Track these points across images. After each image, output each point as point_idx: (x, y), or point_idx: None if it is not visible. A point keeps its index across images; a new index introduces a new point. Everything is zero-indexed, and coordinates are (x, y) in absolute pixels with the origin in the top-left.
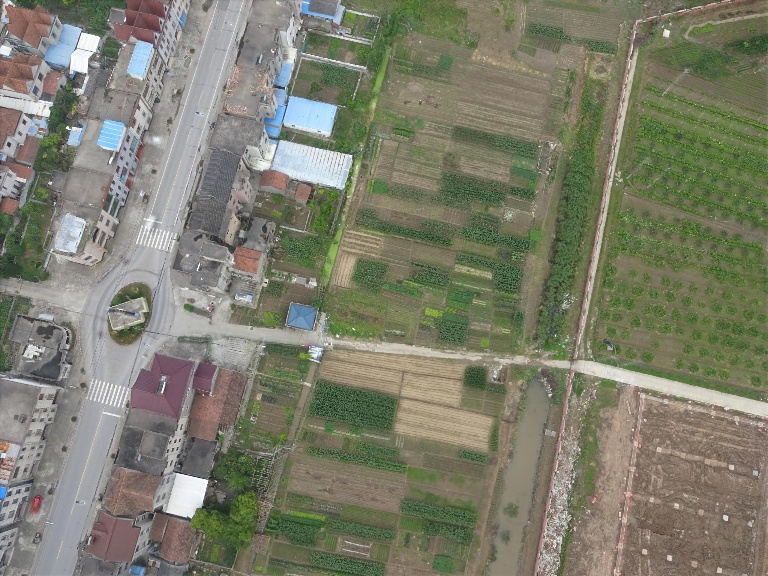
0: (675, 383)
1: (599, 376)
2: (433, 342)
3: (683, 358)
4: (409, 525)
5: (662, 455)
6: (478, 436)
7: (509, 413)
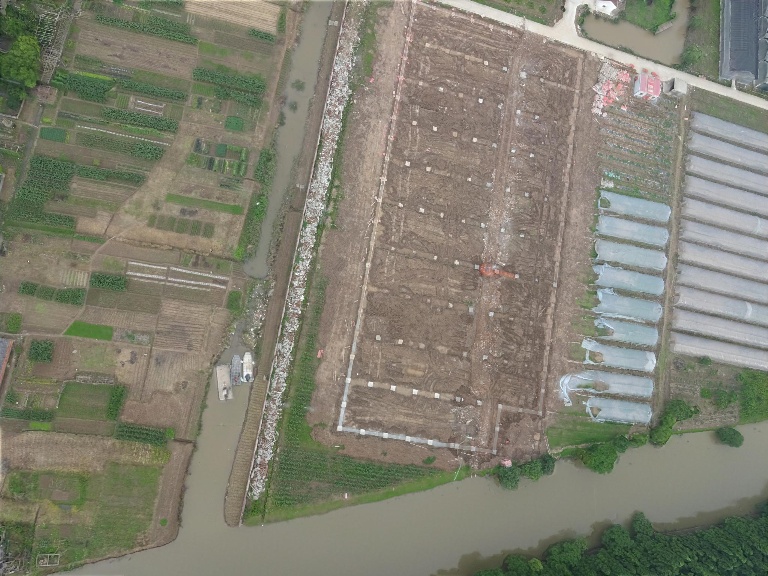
0: None
1: None
2: None
3: None
4: (201, 90)
5: (430, 49)
6: (267, 20)
7: (295, 2)
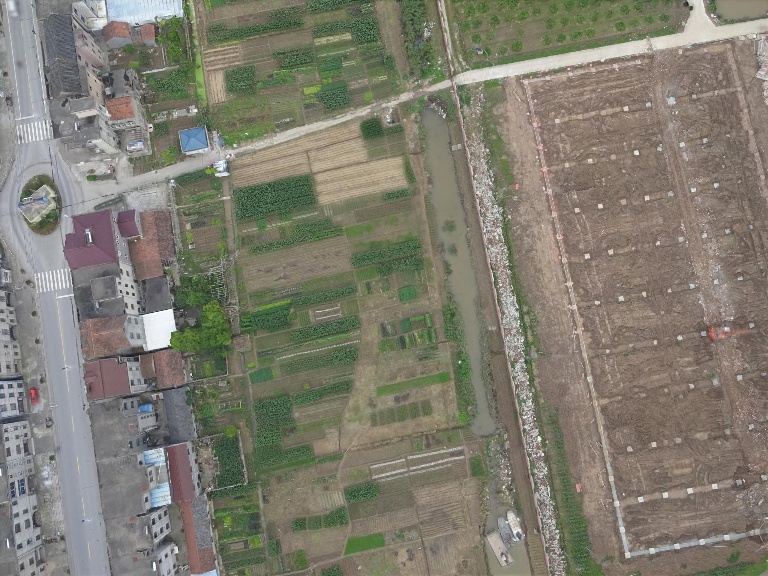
0: (549, 58)
1: (480, 81)
2: (322, 115)
3: (549, 34)
4: (365, 275)
5: (562, 124)
6: (395, 177)
7: (413, 145)
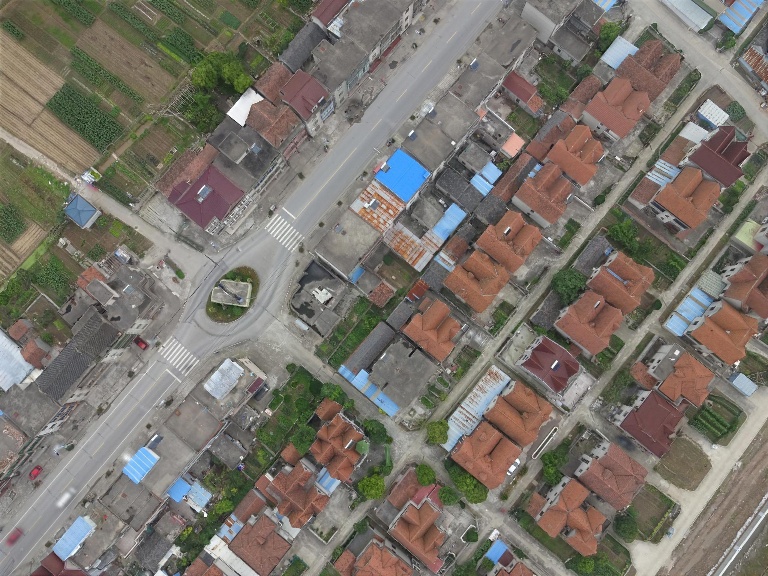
0: None
1: None
2: None
3: None
4: (95, 6)
5: None
6: (0, 44)
7: None
